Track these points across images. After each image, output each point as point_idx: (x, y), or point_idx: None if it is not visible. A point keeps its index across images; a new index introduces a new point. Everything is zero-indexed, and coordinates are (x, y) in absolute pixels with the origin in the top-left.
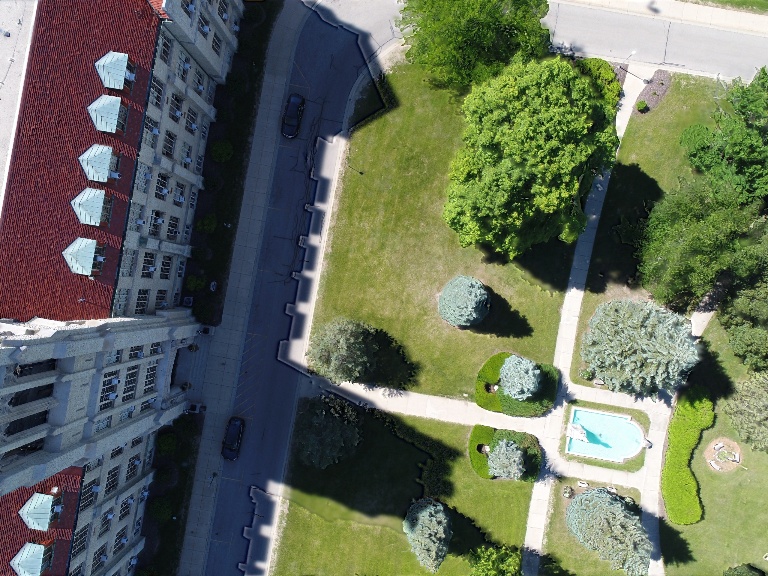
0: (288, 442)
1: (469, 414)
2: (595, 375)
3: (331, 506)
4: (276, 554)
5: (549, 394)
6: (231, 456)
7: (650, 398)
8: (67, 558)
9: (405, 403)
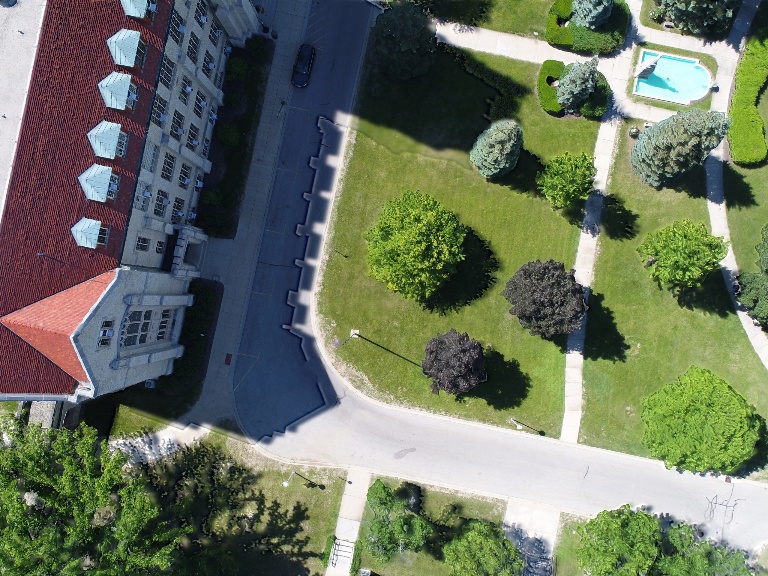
0: (358, 74)
1: (539, 52)
2: (666, 14)
3: (398, 138)
4: (342, 184)
5: (621, 26)
6: (301, 82)
7: (719, 43)
8: (157, 70)
9: (475, 39)
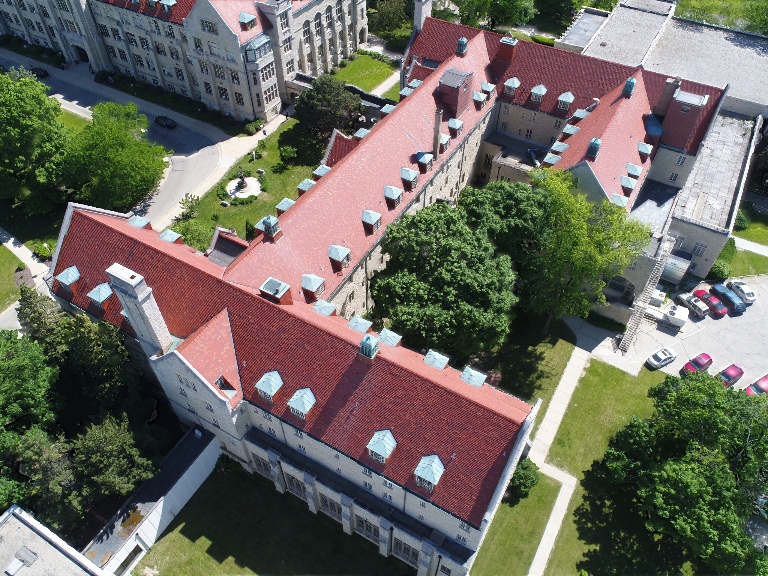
0: None
1: None
2: None
3: None
4: None
5: None
6: None
7: None
8: None
9: None
